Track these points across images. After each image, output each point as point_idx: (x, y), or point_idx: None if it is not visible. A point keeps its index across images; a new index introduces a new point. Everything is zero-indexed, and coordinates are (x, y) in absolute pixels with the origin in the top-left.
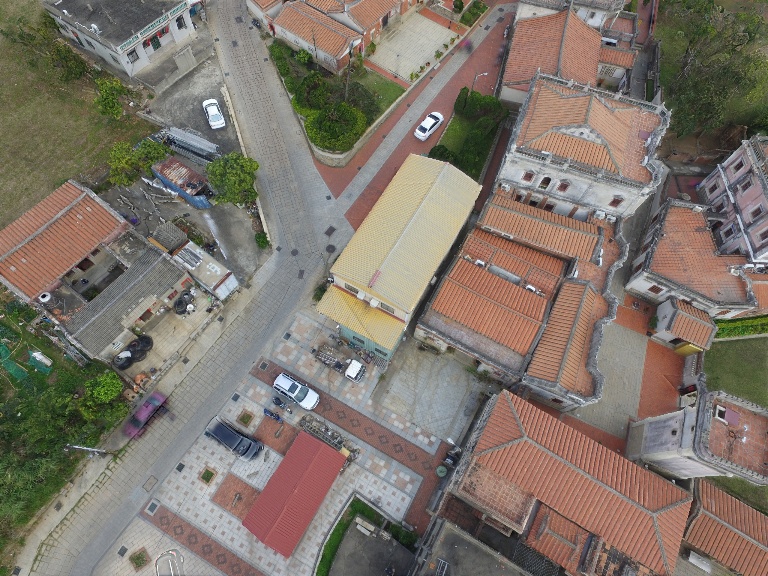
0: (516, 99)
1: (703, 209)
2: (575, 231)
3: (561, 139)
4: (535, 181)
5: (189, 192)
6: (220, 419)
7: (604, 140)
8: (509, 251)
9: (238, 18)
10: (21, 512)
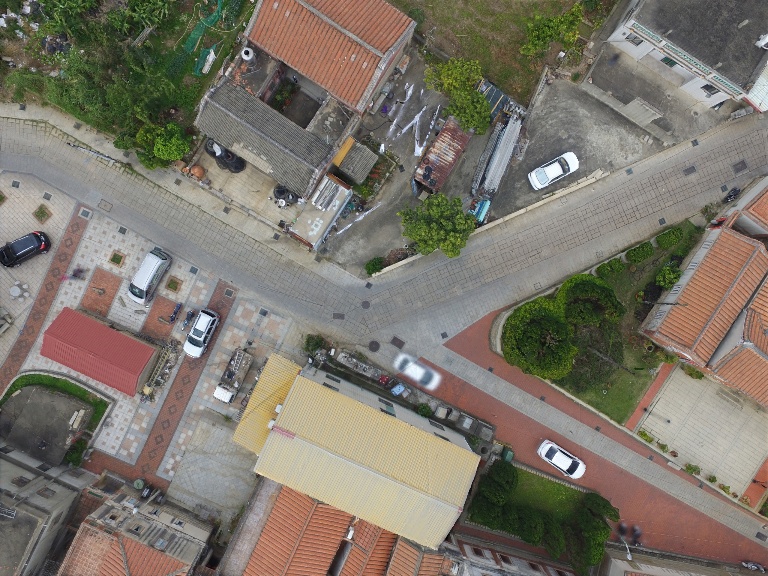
0: None
1: None
2: None
3: None
4: None
5: (418, 172)
6: (160, 265)
7: None
8: (368, 568)
9: (744, 165)
10: None
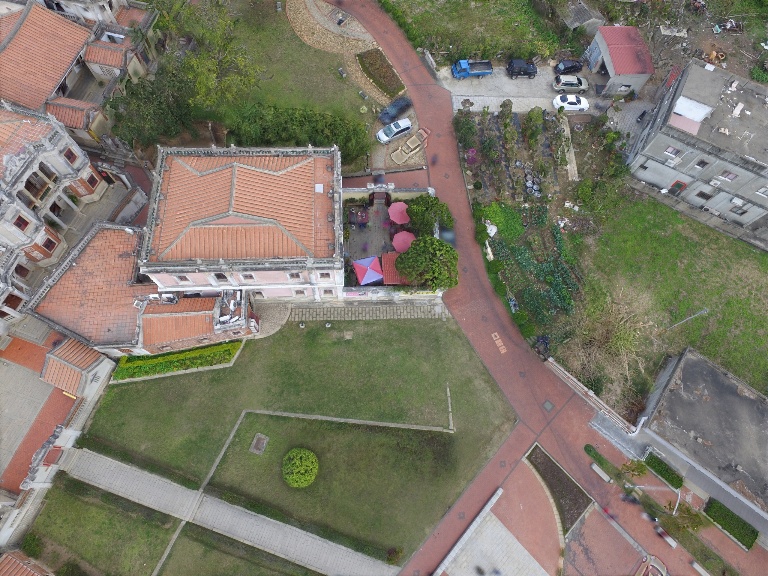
0: None
1: (138, 231)
2: None
3: None
4: None
5: None
6: None
7: None
8: None
9: None
10: None
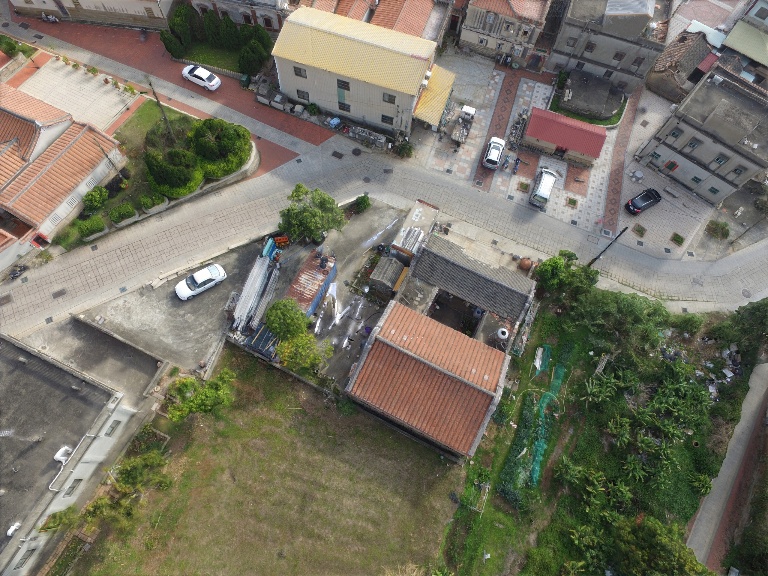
0: (169, 4)
1: None
2: None
3: None
4: None
5: (332, 264)
6: (537, 191)
7: None
8: (348, 10)
9: None
10: None
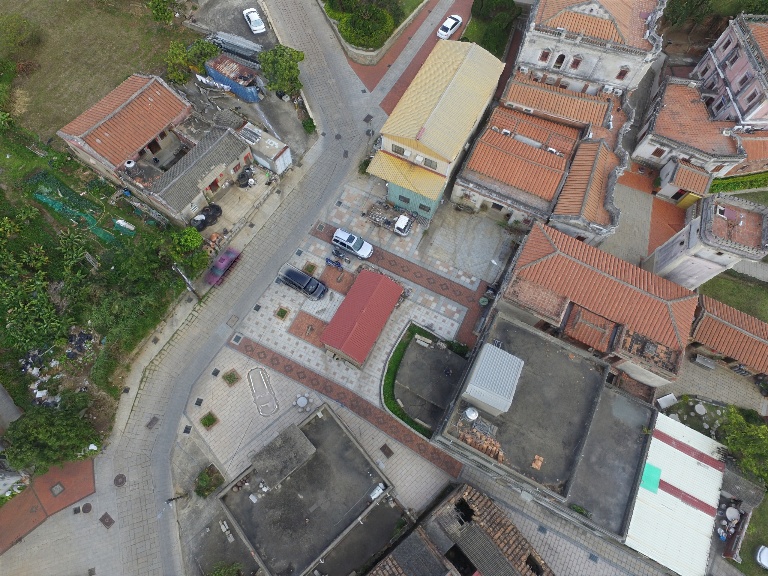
0: (527, 0)
1: (697, 85)
2: (588, 100)
3: (573, 17)
4: (551, 60)
5: (242, 83)
6: (290, 264)
7: (611, 15)
8: (531, 122)
9: None
10: (129, 337)
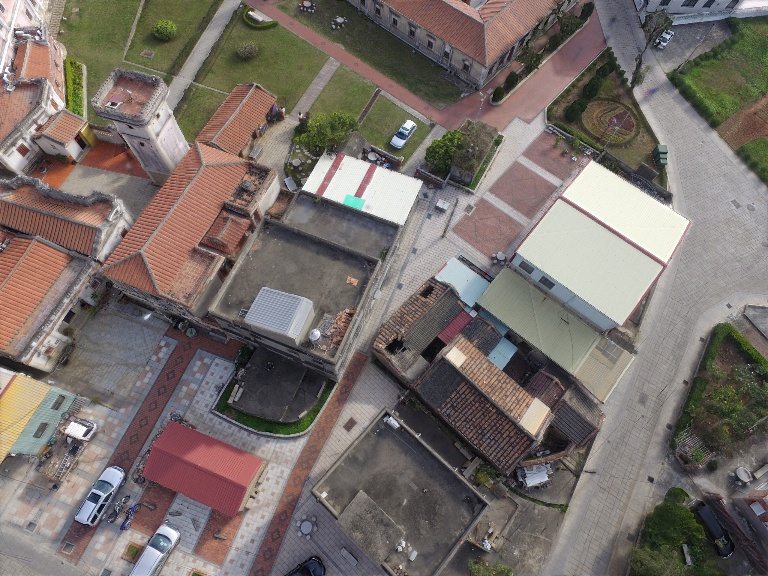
0: None
1: None
2: None
3: None
4: None
5: None
6: None
7: None
8: None
9: None
10: None
